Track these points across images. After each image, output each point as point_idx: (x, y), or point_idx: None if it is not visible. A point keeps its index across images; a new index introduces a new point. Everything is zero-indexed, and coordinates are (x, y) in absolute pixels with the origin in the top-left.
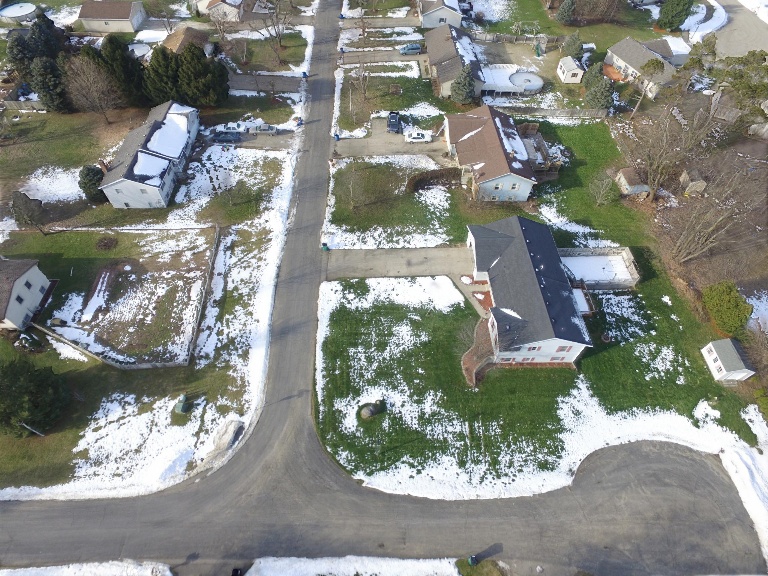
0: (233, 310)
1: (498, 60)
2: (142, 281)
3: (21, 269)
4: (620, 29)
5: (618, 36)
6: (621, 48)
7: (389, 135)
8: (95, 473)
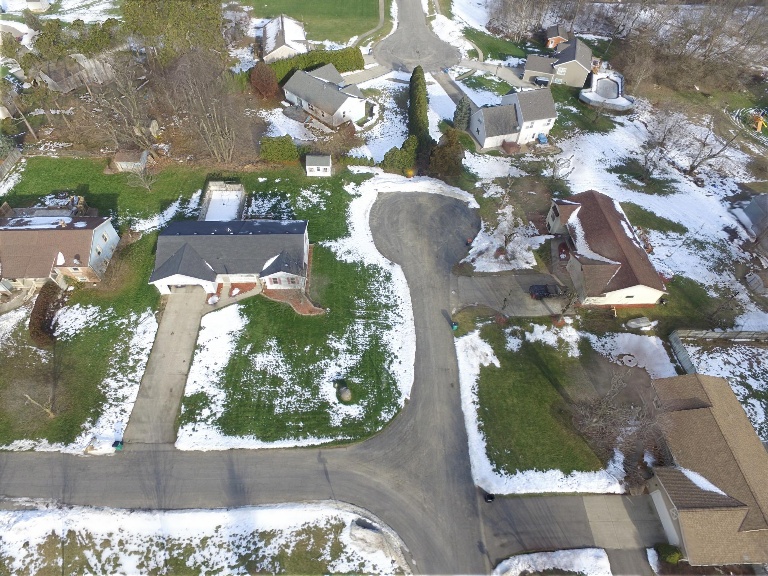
0: (192, 569)
1: None
2: None
3: None
4: None
5: None
6: None
7: None
8: None
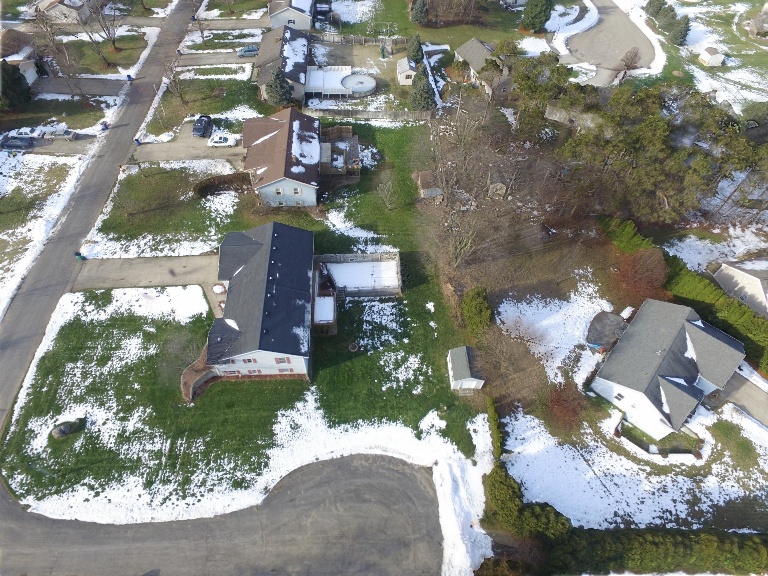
0: None
1: (339, 62)
2: None
3: None
4: (481, 30)
5: (476, 37)
6: (466, 49)
7: (195, 139)
8: None
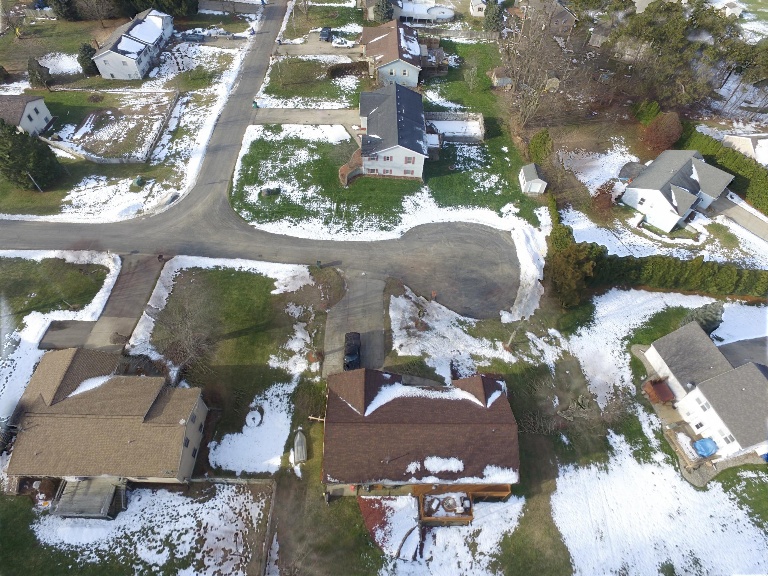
0: (182, 137)
1: None
2: (119, 120)
3: (32, 98)
4: None
5: None
6: None
7: (321, 43)
8: (75, 211)
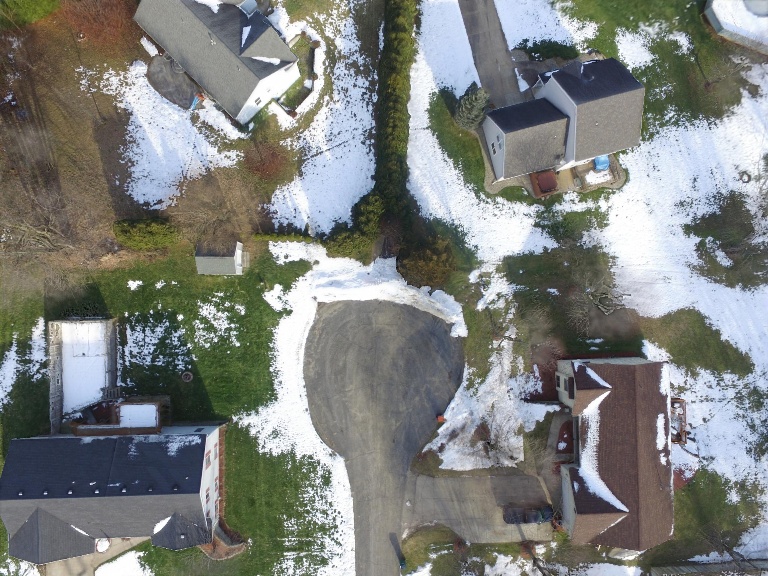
0: None
1: None
2: None
3: None
4: None
5: None
6: None
7: None
8: None
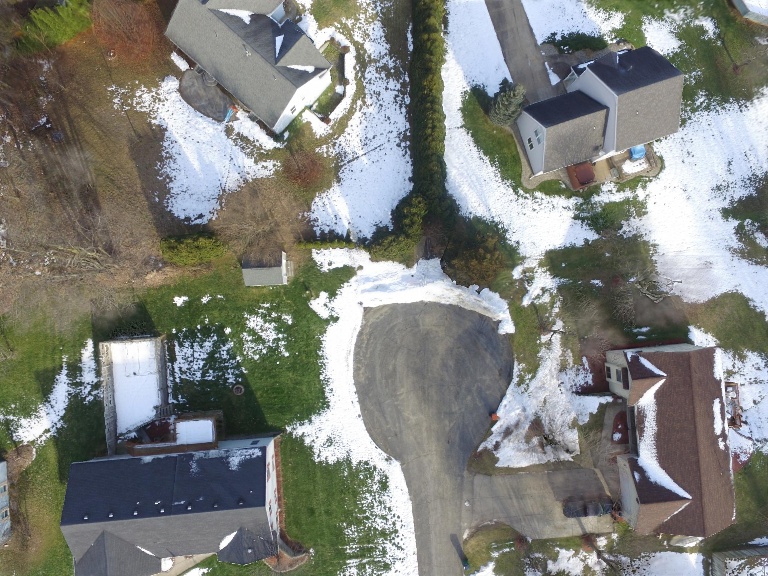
0: None
1: None
2: None
3: None
4: None
5: None
6: None
7: None
8: None
